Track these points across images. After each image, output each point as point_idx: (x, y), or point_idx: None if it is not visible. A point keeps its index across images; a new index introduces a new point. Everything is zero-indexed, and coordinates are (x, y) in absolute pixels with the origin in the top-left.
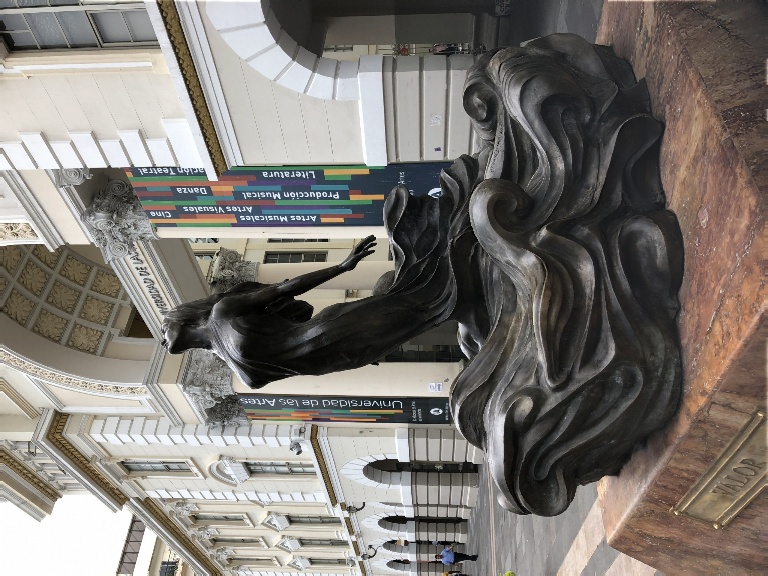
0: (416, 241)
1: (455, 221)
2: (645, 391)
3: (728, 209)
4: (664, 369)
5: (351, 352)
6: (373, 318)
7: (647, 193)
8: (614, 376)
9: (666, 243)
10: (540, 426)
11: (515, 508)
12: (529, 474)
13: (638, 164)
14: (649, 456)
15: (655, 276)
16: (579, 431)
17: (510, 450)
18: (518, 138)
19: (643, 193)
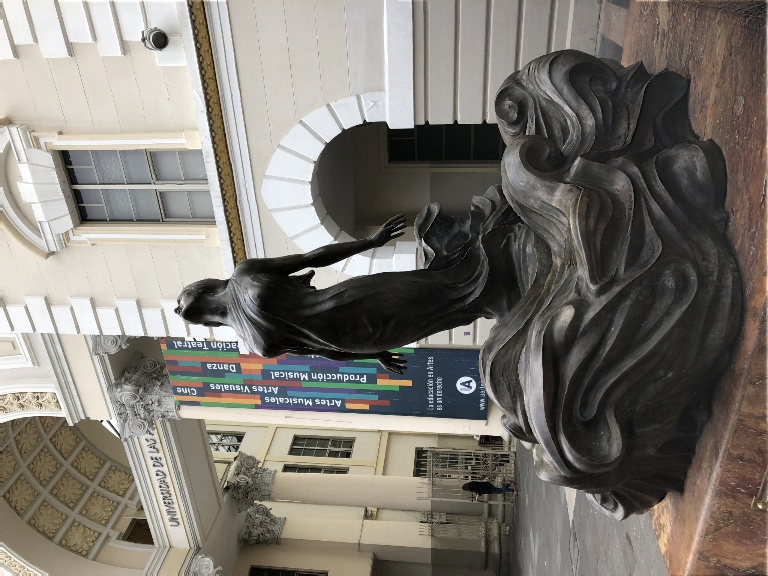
0: (447, 242)
1: (487, 223)
2: (701, 297)
3: (762, 66)
4: (720, 273)
5: (374, 318)
6: (399, 282)
7: (680, 140)
8: (664, 278)
9: (705, 154)
10: (584, 341)
11: (558, 467)
12: (574, 415)
13: (668, 116)
14: (716, 420)
15: (697, 191)
16: (629, 348)
17: (550, 377)
18: (548, 124)
19: (676, 140)
